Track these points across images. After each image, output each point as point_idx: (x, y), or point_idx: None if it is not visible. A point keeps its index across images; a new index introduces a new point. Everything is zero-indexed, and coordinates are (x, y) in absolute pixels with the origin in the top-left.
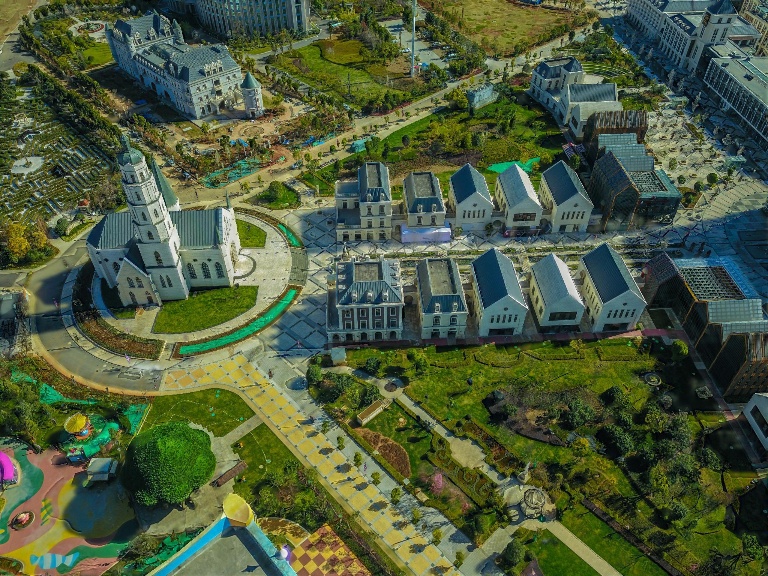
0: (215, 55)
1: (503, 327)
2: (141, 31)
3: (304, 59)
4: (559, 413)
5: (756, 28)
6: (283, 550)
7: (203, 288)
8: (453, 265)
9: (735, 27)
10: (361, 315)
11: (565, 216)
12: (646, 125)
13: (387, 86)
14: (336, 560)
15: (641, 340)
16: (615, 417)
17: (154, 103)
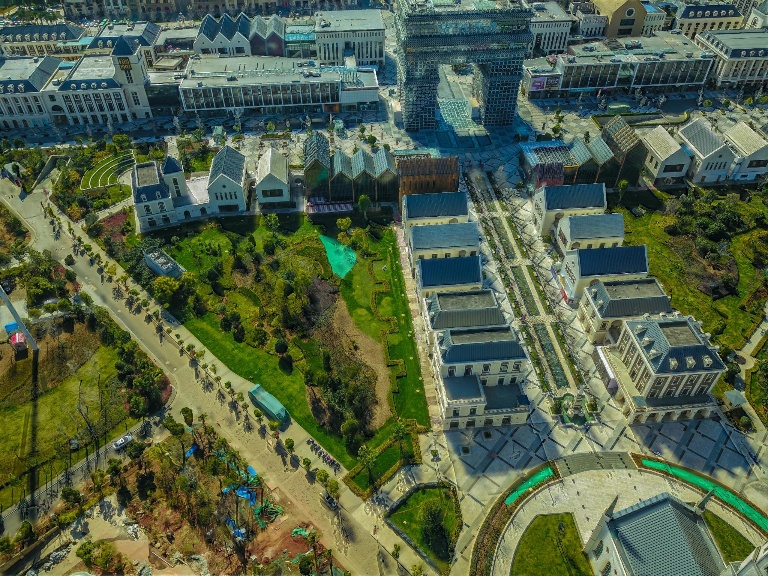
0: None
1: None
2: None
3: None
4: None
5: None
6: None
7: None
8: None
9: None
10: None
11: None
12: (328, 141)
13: None
14: None
15: None
16: (702, 227)
17: None
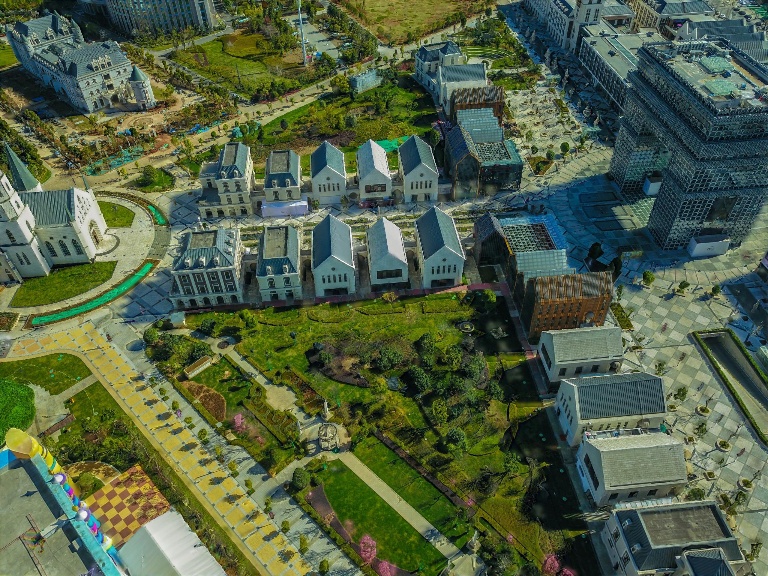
0: (104, 51)
1: (336, 287)
2: (39, 31)
3: (205, 53)
4: (369, 359)
5: (635, 8)
6: (59, 476)
7: (64, 265)
8: (290, 232)
9: (610, 7)
10: (198, 280)
11: (414, 186)
12: (502, 100)
13: (279, 75)
14: (140, 494)
15: (465, 294)
16: (418, 360)
17: (52, 100)
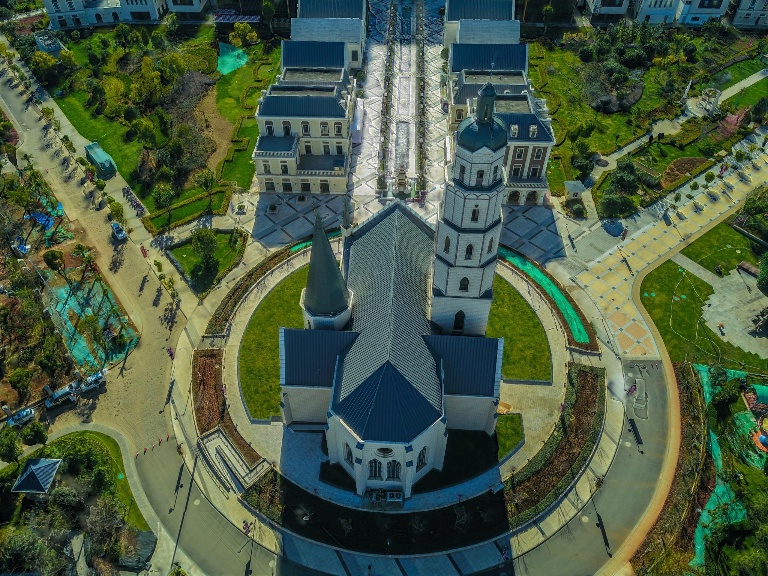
0: None
1: None
2: None
3: None
4: None
5: None
6: None
7: None
8: None
9: None
10: None
11: None
12: None
13: None
14: None
15: None
16: (618, 52)
17: None
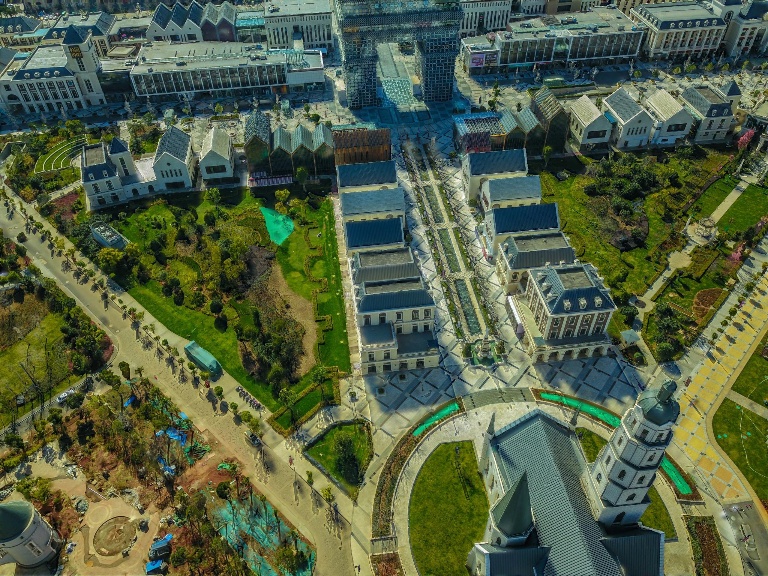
0: None
1: None
2: None
3: None
4: None
5: None
6: None
7: None
8: None
9: None
10: None
11: None
12: (268, 118)
13: None
14: None
15: None
16: (618, 187)
17: None
